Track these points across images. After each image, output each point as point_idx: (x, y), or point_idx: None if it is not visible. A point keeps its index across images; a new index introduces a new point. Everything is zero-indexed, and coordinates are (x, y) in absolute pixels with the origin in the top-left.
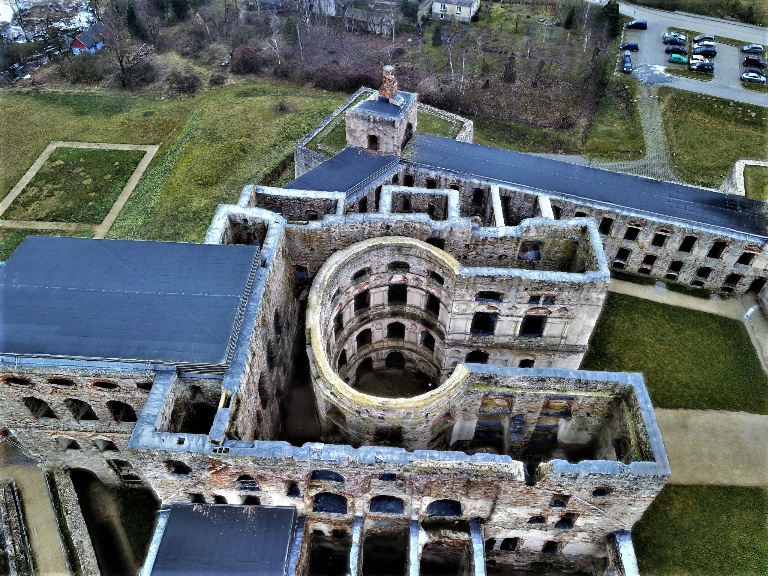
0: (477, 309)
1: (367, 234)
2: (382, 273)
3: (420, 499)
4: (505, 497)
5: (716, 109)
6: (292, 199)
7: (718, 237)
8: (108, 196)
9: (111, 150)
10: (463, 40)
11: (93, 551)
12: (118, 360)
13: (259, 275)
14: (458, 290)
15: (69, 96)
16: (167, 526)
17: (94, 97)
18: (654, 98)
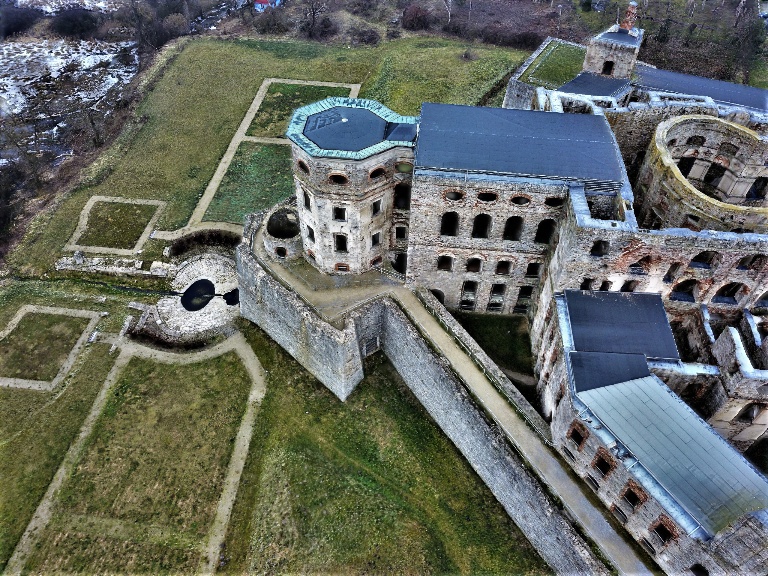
0: (761, 174)
1: (664, 118)
2: (681, 146)
3: (764, 285)
4: None
5: None
6: None
7: None
8: None
9: (320, 86)
10: (609, 7)
11: (473, 339)
12: (544, 177)
13: None
14: (754, 155)
15: (265, 43)
16: (569, 302)
17: (288, 44)
18: None
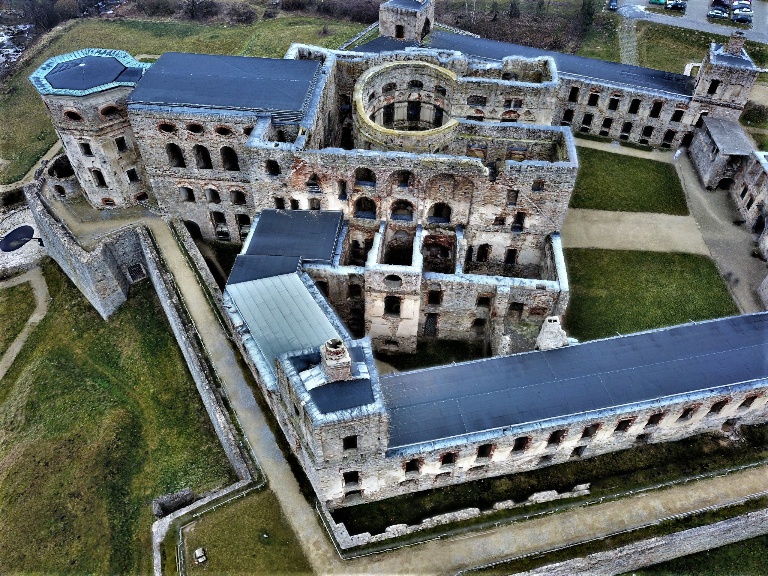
0: (468, 113)
1: None
2: (404, 90)
3: (423, 200)
4: (477, 194)
5: (683, 37)
6: (340, 57)
7: (656, 98)
8: None
9: None
10: None
11: (203, 259)
12: (234, 108)
13: (321, 77)
14: (455, 95)
15: (148, 24)
16: (260, 218)
17: (169, 25)
18: (633, 28)
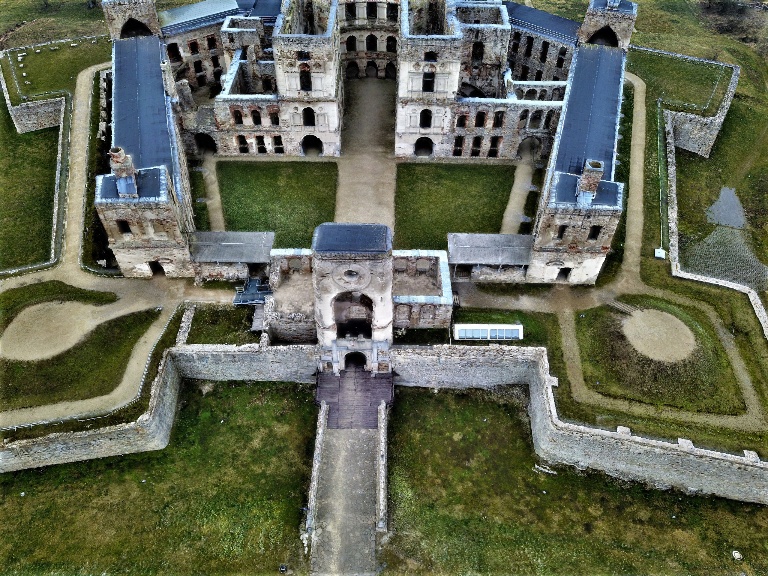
0: None
1: None
2: None
3: None
4: None
5: None
6: None
7: None
8: None
9: None
10: None
11: None
12: None
13: None
14: None
15: None
16: None
17: (682, 0)
18: None
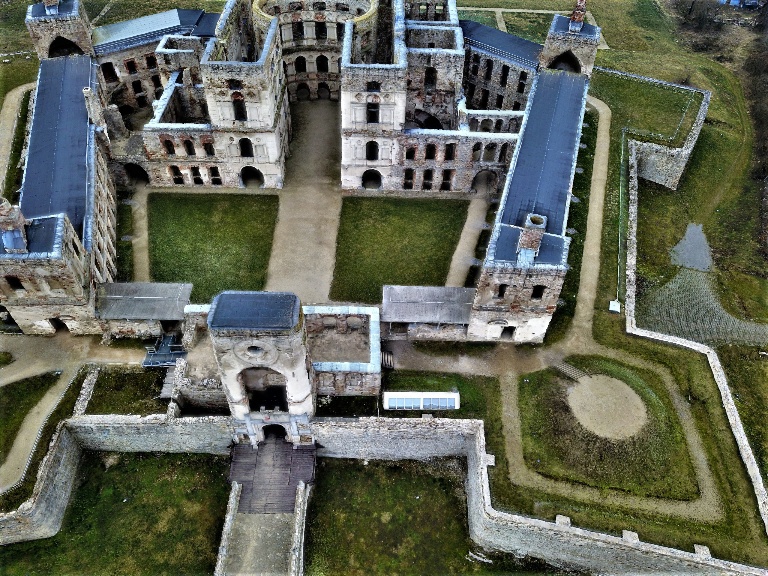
0: None
1: None
2: None
3: None
4: None
5: None
6: None
7: None
8: (540, 40)
9: None
10: None
11: None
12: None
13: None
14: None
15: (652, 7)
16: None
17: (657, 15)
18: None
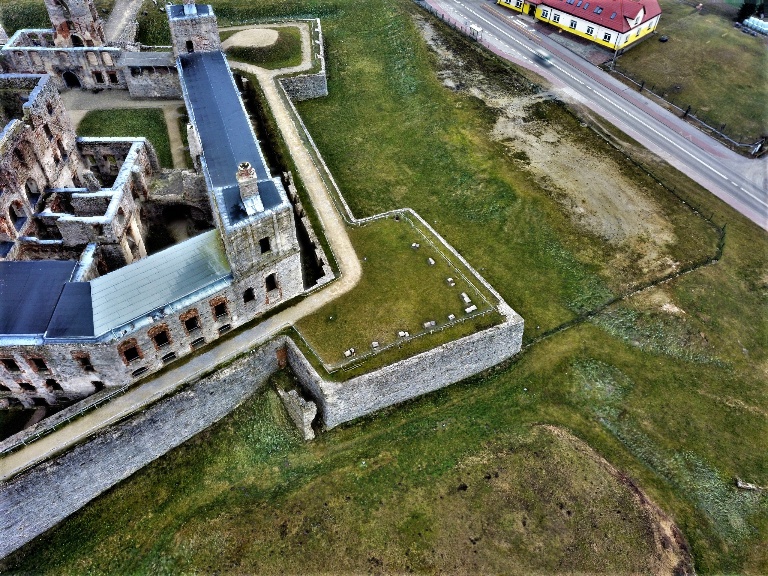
0: None
1: None
2: None
3: (21, 189)
4: (36, 149)
5: None
6: None
7: None
8: None
9: None
10: None
11: None
12: None
13: None
14: None
15: None
16: None
17: None
18: None
